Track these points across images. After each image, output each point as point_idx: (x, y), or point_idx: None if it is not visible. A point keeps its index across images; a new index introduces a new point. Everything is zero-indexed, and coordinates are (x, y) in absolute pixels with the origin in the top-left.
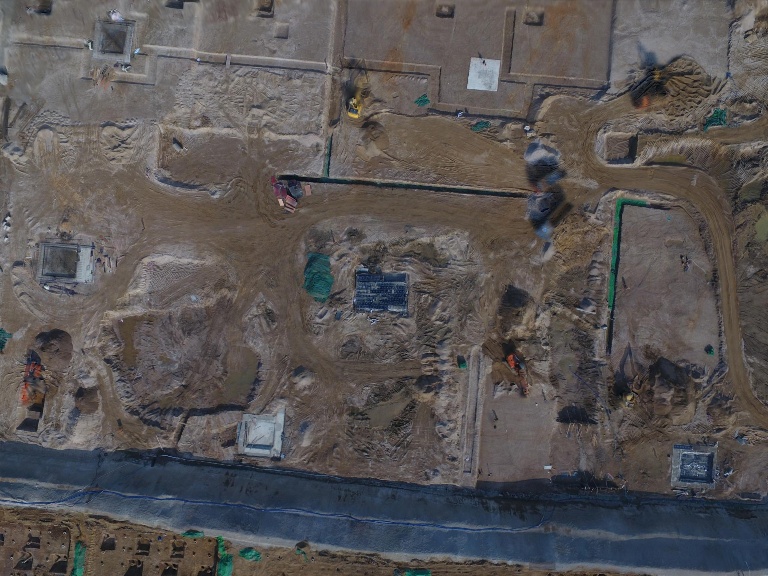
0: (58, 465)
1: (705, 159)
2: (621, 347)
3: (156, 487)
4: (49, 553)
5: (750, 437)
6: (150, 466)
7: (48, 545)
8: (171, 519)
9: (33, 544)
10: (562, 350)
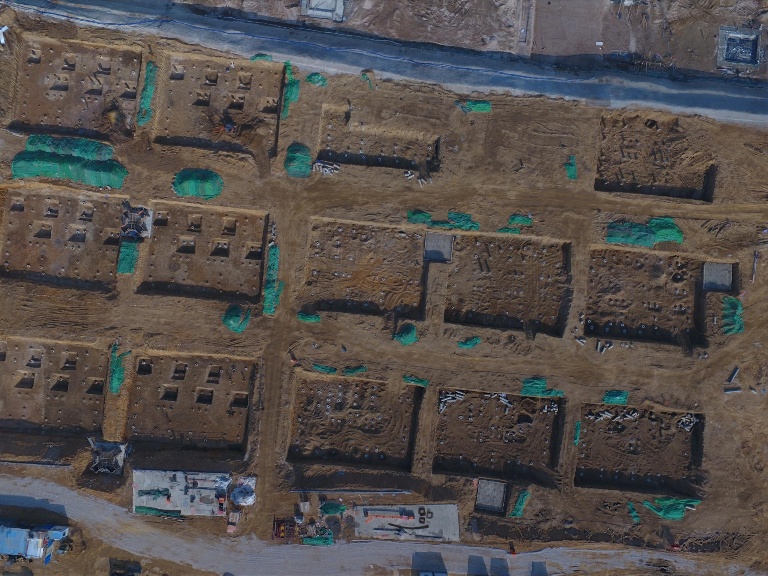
0: (128, 6)
1: None
2: None
3: (224, 27)
4: (119, 79)
5: None
6: (216, 19)
7: (119, 71)
8: (240, 46)
9: (103, 72)
10: None
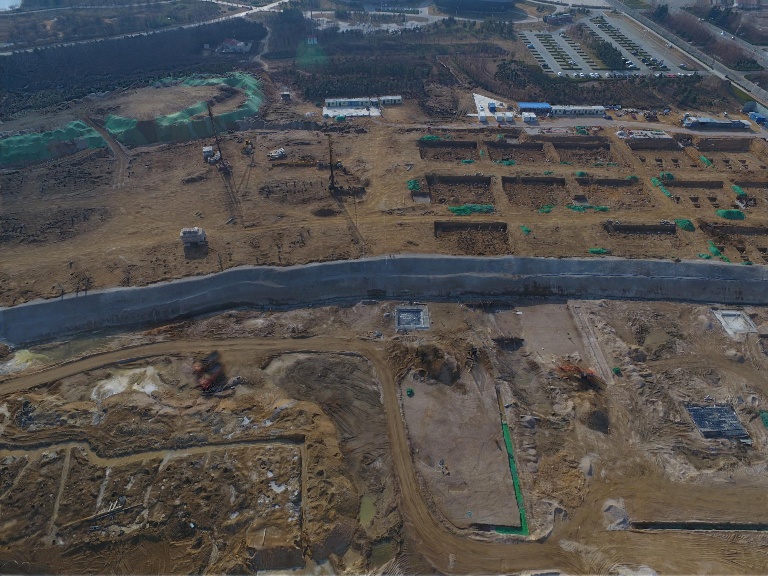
0: None
1: None
2: (488, 392)
3: None
4: None
5: None
6: None
7: None
8: (766, 270)
9: None
10: (533, 390)
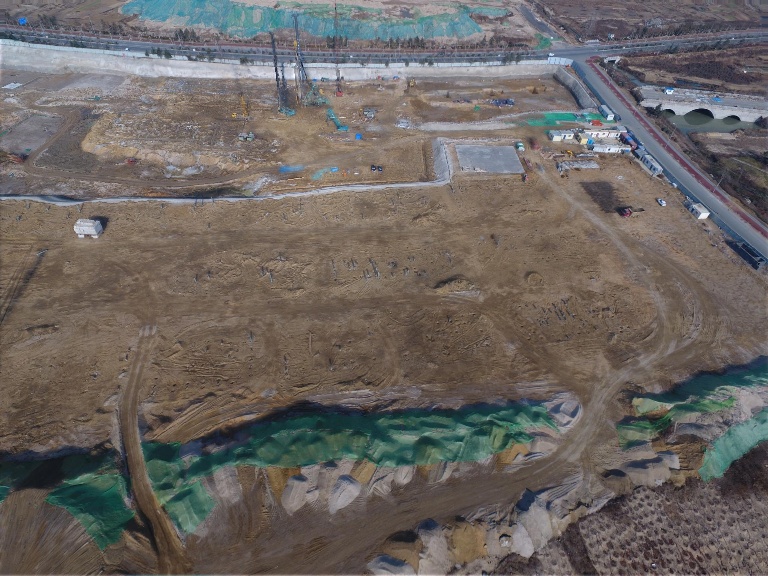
0: None
1: (83, 108)
2: None
3: None
4: None
5: None
6: None
7: None
8: None
9: None
10: None
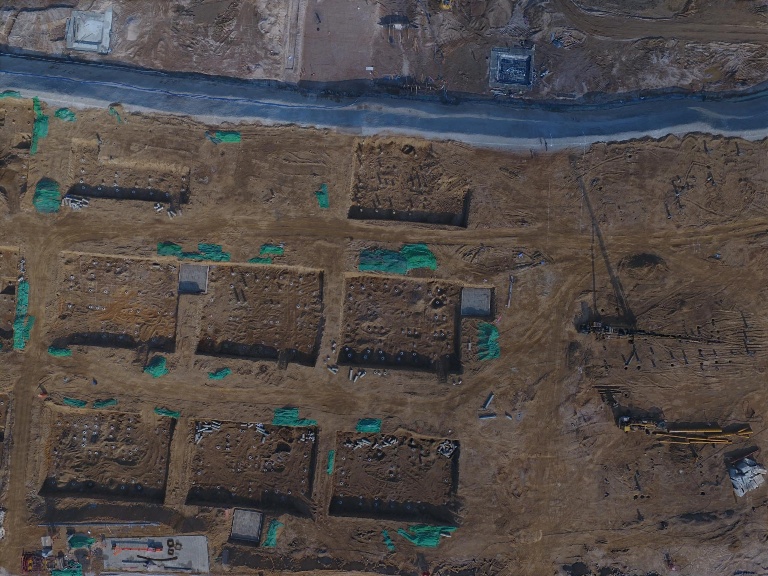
0: None
1: None
2: None
3: None
4: None
5: (566, 39)
6: None
7: None
8: None
9: None
10: None
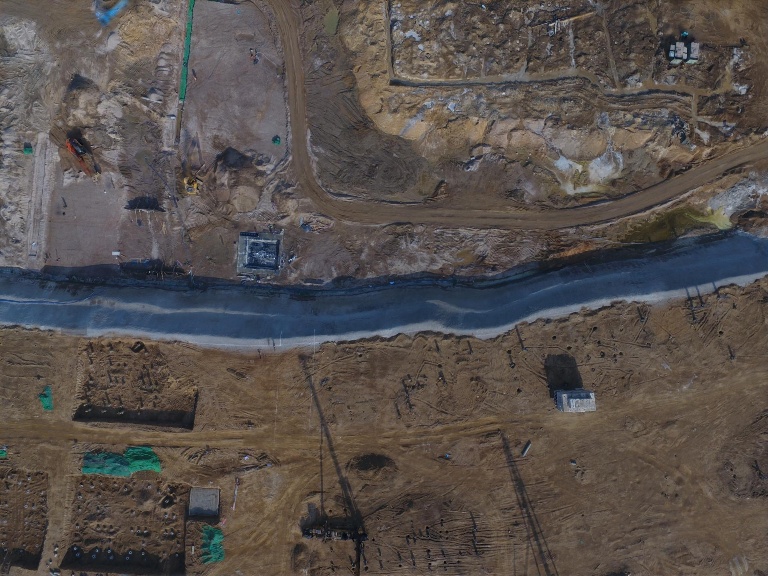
0: None
1: None
2: (189, 137)
3: None
4: None
5: (314, 224)
6: None
7: None
8: None
9: None
10: (137, 142)
